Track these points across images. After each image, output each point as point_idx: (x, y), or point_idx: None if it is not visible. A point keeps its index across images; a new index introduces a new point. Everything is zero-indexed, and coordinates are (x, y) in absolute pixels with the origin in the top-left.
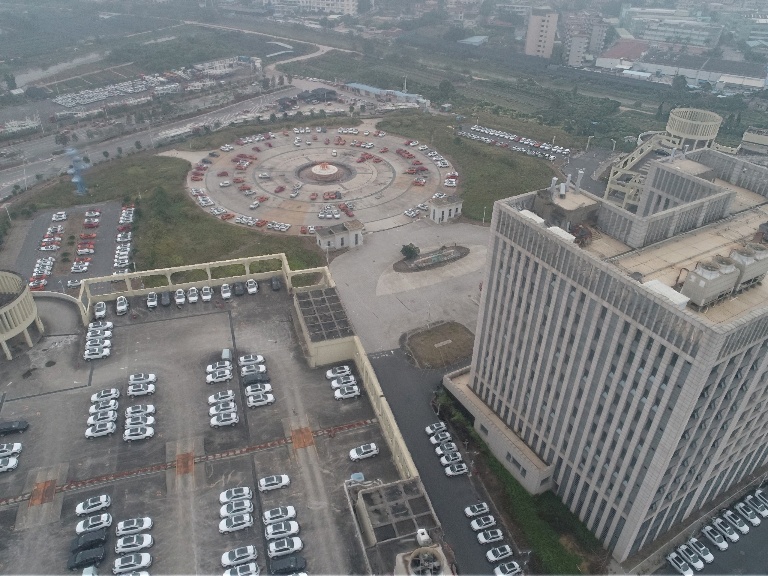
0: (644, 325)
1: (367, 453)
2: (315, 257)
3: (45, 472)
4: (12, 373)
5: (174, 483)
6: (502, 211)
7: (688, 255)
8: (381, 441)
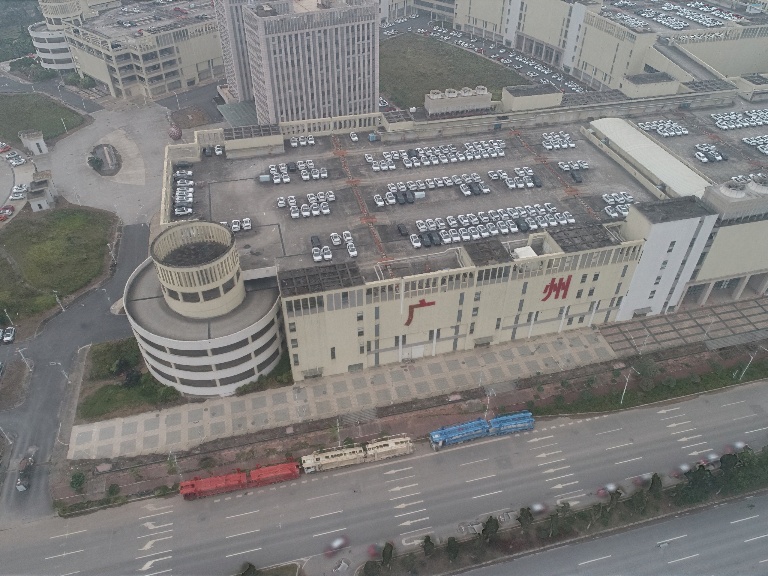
0: (354, 22)
1: (356, 135)
2: (62, 211)
3: (353, 223)
4: (253, 261)
5: (366, 184)
6: (266, 21)
7: (303, 9)
8: (346, 135)
